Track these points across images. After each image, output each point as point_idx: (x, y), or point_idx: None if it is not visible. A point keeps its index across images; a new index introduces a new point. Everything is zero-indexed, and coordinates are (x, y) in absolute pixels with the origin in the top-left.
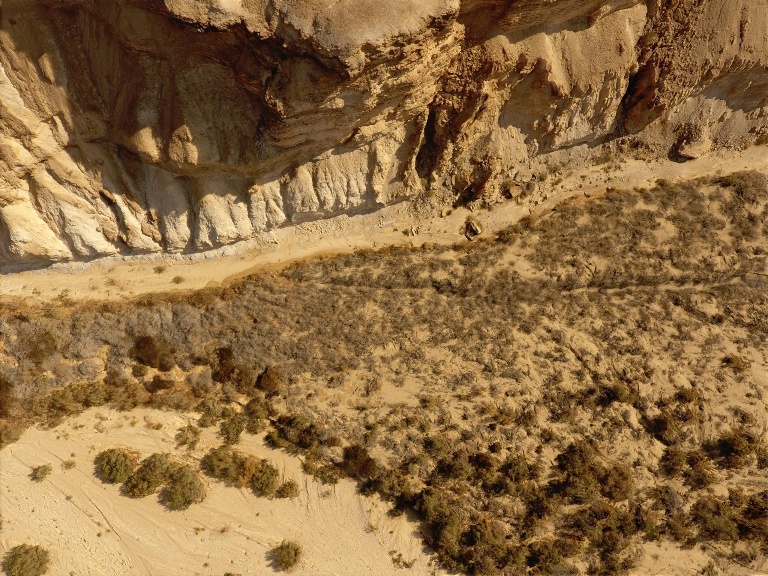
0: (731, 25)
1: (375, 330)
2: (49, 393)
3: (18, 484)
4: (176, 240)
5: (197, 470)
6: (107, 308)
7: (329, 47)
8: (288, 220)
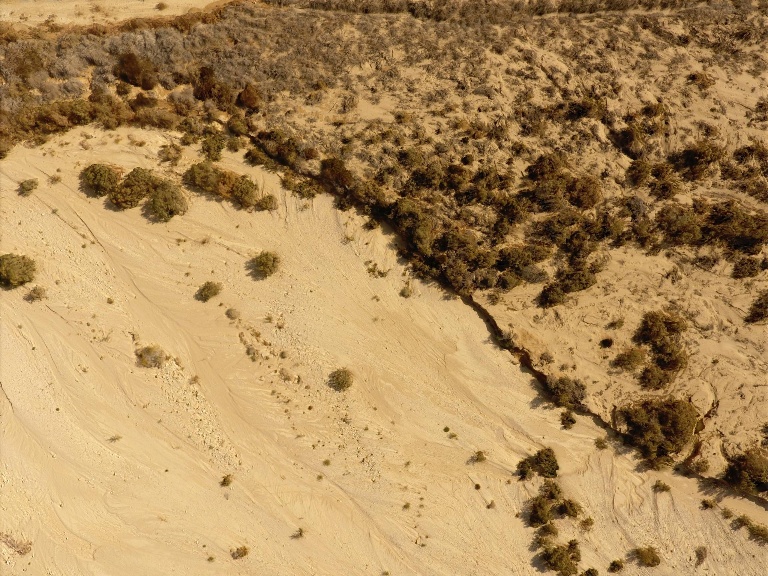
0: None
1: (352, 50)
2: None
3: (5, 198)
4: None
5: (179, 185)
6: (92, 30)
7: None
8: None
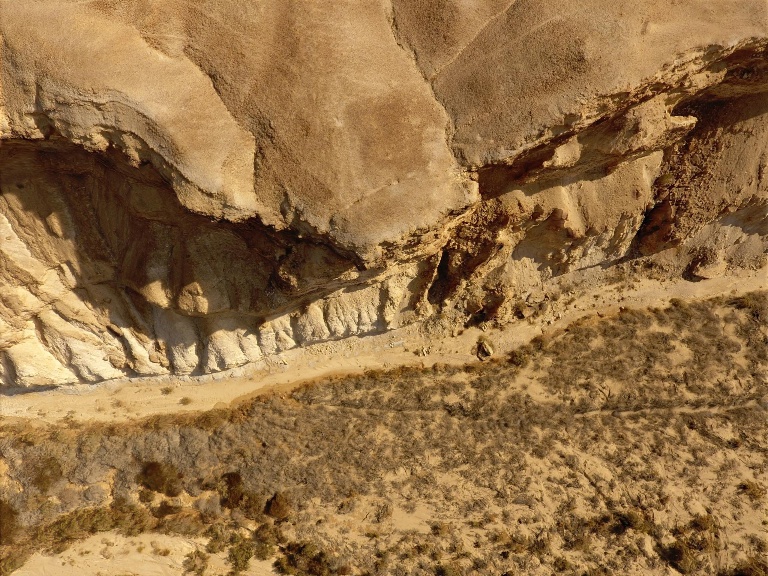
0: (749, 169)
1: (386, 454)
2: (54, 519)
3: None
4: (184, 366)
5: None
6: (113, 431)
7: (346, 243)
8: (298, 345)
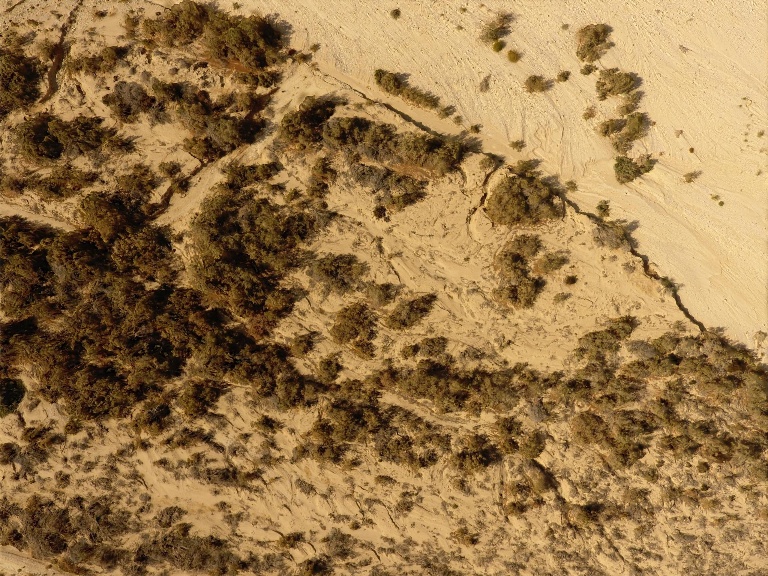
0: None
1: None
2: None
3: None
4: None
5: None
6: None
7: None
8: None
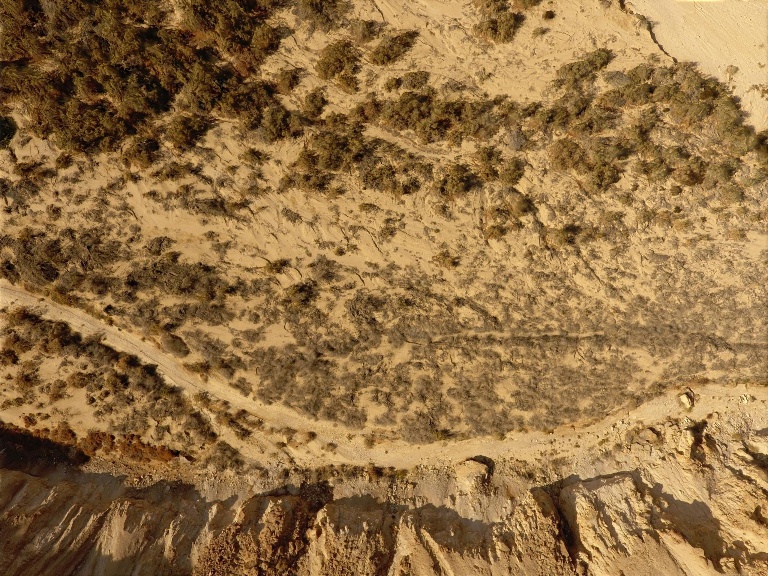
0: None
1: None
2: None
3: None
4: None
5: None
6: None
7: None
8: None
